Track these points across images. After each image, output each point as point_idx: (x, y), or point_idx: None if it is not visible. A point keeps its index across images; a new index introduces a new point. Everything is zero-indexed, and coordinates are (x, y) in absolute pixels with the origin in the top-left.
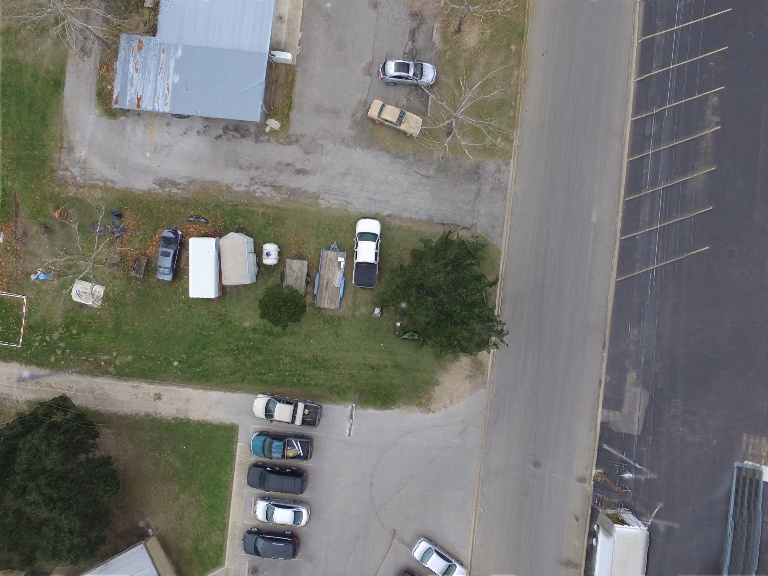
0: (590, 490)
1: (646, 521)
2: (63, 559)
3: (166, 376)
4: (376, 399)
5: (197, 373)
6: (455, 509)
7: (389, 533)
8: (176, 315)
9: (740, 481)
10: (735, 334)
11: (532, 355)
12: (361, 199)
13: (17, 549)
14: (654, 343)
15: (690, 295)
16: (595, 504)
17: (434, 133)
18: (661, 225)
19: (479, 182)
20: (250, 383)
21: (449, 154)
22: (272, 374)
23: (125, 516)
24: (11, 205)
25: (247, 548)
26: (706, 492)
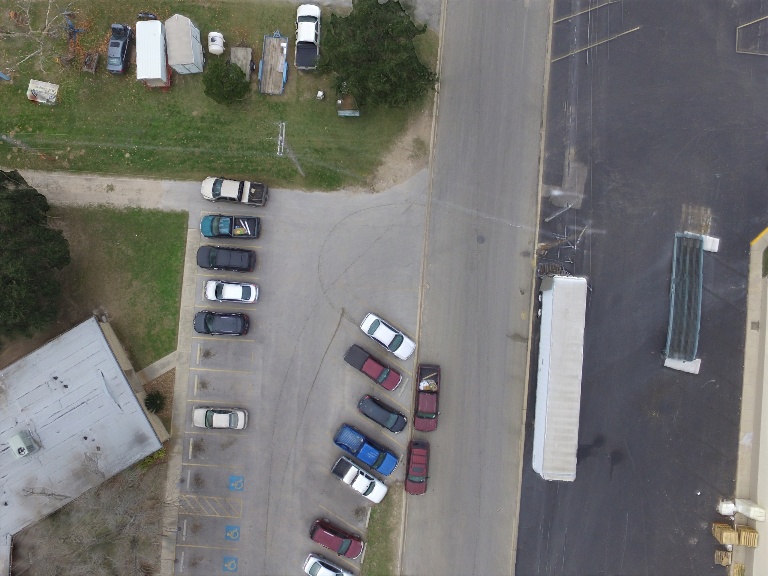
0: (534, 264)
1: (588, 285)
2: (12, 314)
3: (118, 168)
4: (321, 181)
5: (148, 163)
6: (401, 286)
7: (337, 312)
8: (127, 108)
9: (681, 250)
10: (668, 108)
11: (472, 134)
12: None
13: None
14: (590, 120)
15: (623, 72)
16: (538, 273)
17: None
18: (592, 8)
19: None
20: (199, 171)
21: None
22: (220, 161)
23: (79, 305)
24: None
25: (197, 326)
26: (648, 263)
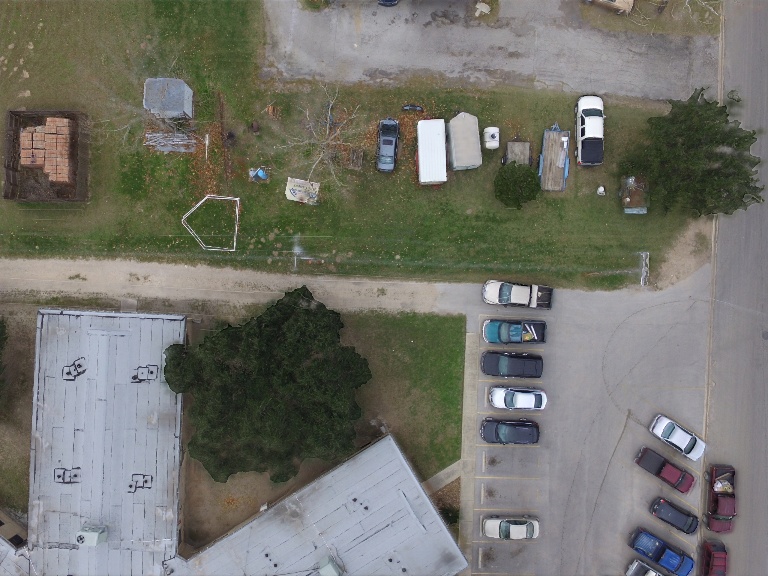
0: None
1: None
2: (330, 446)
3: (388, 271)
4: (603, 279)
5: (420, 265)
6: (687, 385)
7: (623, 413)
8: (396, 207)
9: None
10: None
11: (754, 226)
12: (577, 79)
13: (286, 437)
14: None
15: None
16: None
17: (644, 9)
18: None
19: (691, 57)
20: (475, 272)
21: (660, 30)
22: (497, 261)
23: None
24: (215, 106)
25: (487, 436)
26: None
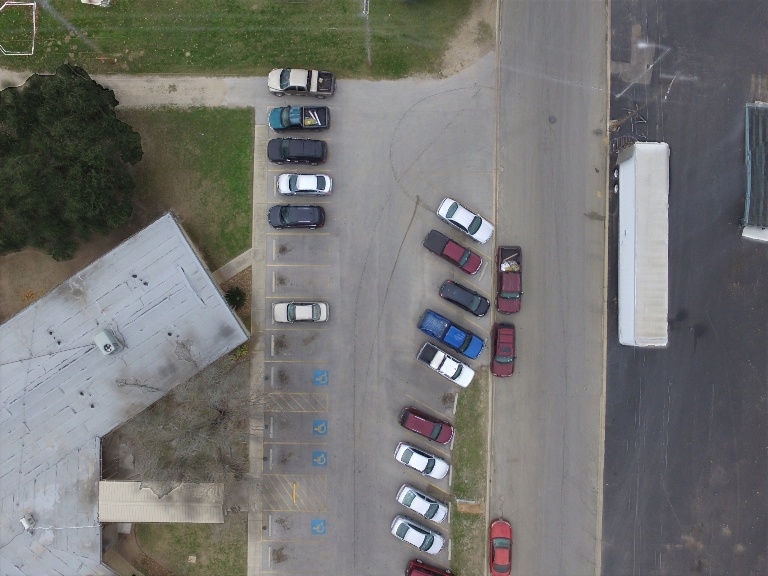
0: (607, 141)
1: None
2: (91, 205)
3: (179, 68)
4: (388, 69)
5: (210, 61)
6: (475, 170)
7: (412, 200)
8: (185, 6)
9: (753, 119)
10: None
11: (537, 14)
12: None
13: (45, 194)
14: None
15: None
16: (613, 148)
17: None
18: None
19: None
20: (263, 66)
21: None
22: (284, 55)
23: (149, 209)
24: None
25: (273, 220)
26: (721, 134)
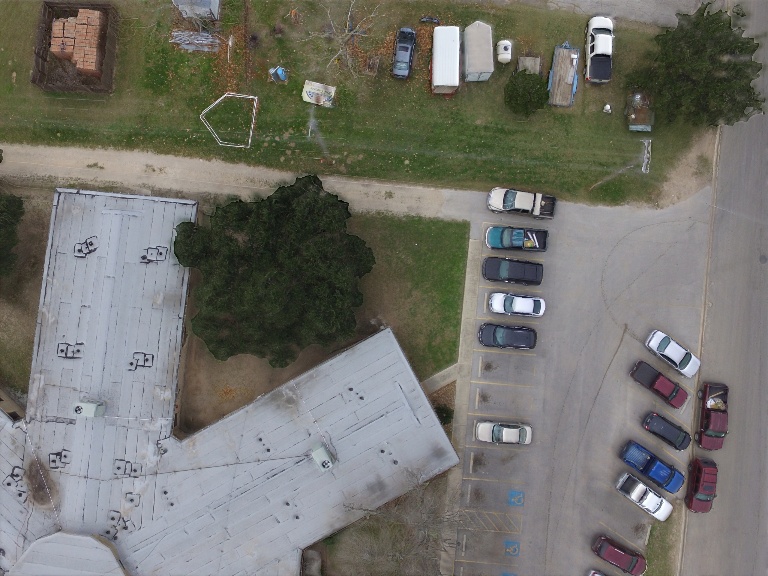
0: None
1: None
2: (331, 324)
3: (397, 175)
4: (606, 195)
5: (428, 171)
6: (684, 303)
7: (620, 328)
8: (408, 114)
9: None
10: None
11: (754, 153)
12: (588, 3)
13: (288, 311)
14: None
15: None
16: None
17: None
18: None
19: None
20: (481, 181)
21: None
22: (503, 172)
23: (356, 314)
24: (240, 10)
25: (485, 339)
26: None
